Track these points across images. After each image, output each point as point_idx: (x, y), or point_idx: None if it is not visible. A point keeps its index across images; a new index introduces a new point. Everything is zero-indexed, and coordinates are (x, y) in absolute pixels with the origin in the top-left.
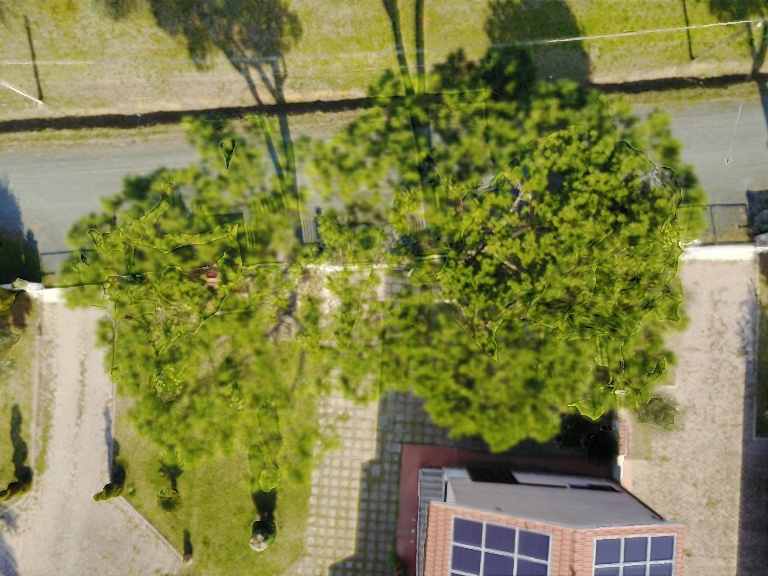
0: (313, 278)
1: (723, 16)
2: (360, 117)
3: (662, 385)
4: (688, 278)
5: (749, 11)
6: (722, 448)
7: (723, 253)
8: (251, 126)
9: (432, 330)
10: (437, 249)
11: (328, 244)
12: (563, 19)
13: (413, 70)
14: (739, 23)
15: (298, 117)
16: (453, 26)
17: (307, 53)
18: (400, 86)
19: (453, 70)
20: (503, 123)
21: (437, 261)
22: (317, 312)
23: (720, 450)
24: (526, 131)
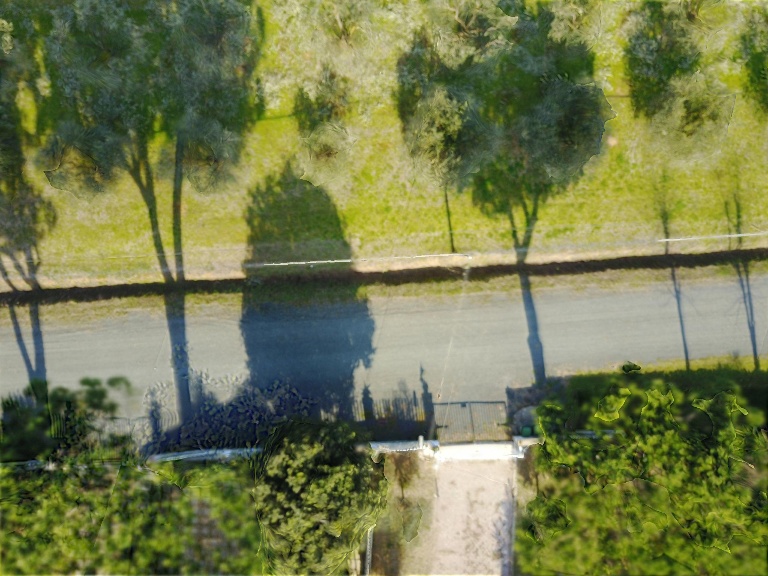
0: (59, 476)
1: (485, 208)
2: (114, 307)
3: None
4: (444, 478)
5: (511, 203)
6: None
7: (479, 453)
8: (0, 316)
9: (182, 529)
10: (185, 448)
11: (77, 439)
12: (323, 208)
13: (171, 258)
14: (501, 215)
15: (50, 307)
16: (211, 214)
17: (61, 240)
18: (158, 273)
19: (211, 258)
20: (259, 315)
21: (182, 463)
22: (64, 510)
23: None
24: (282, 324)
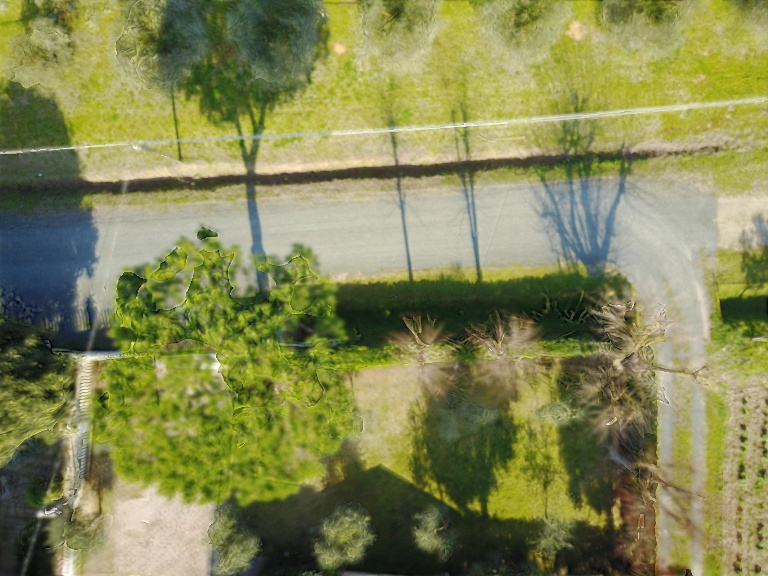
0: None
1: (212, 116)
2: None
3: (133, 497)
4: (166, 387)
5: (238, 111)
6: (191, 563)
7: (199, 362)
8: None
9: None
10: None
11: None
12: (51, 115)
13: None
14: (227, 124)
15: None
16: None
17: None
18: None
19: None
20: None
21: None
22: None
23: (189, 565)
24: (7, 231)
